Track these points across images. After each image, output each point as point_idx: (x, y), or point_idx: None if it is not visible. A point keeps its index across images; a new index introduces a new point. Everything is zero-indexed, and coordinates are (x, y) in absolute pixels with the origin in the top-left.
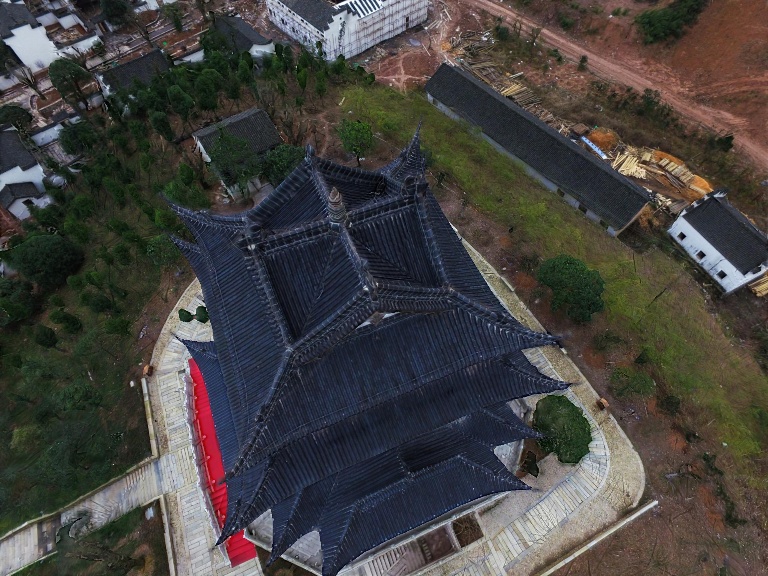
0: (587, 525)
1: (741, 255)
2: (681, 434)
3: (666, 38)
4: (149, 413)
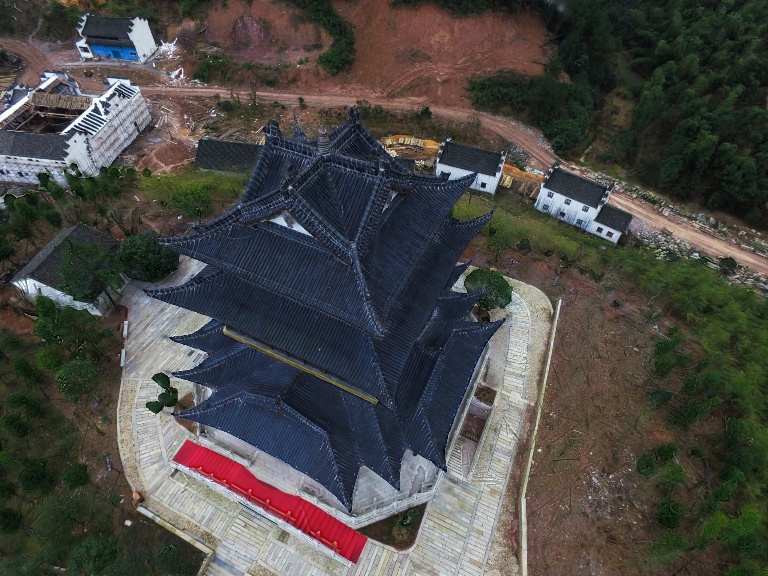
0: (541, 340)
1: (485, 166)
2: (541, 262)
3: (344, 67)
4: (172, 527)
